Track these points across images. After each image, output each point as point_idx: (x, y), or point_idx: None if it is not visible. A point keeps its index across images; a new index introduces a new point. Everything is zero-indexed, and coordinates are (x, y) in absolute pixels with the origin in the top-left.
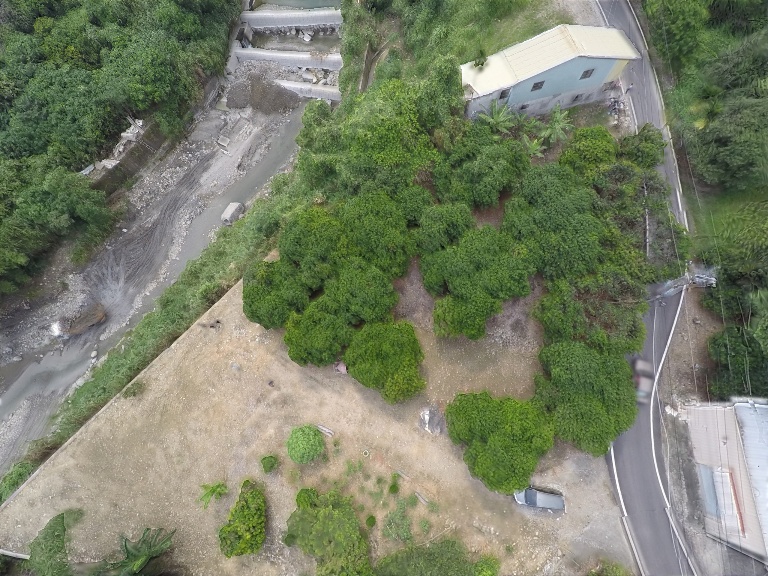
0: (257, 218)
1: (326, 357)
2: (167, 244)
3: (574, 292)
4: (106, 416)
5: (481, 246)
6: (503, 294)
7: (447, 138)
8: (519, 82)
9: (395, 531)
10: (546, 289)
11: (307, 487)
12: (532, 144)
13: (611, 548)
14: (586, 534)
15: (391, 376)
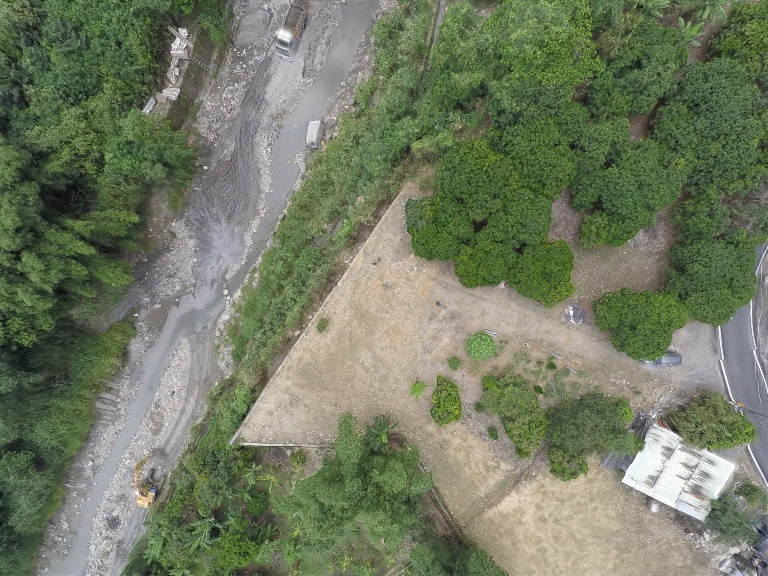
0: (379, 147)
1: (500, 280)
2: (255, 177)
3: (723, 195)
4: (303, 347)
5: (647, 164)
6: (659, 206)
7: (618, 44)
8: None
9: (556, 393)
10: (688, 192)
11: (483, 374)
12: (685, 29)
13: (709, 380)
14: (692, 374)
15: (554, 287)
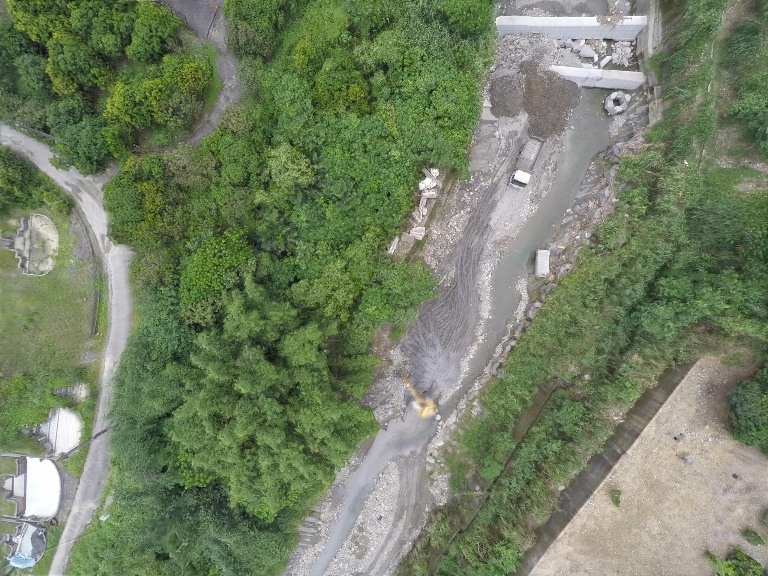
0: (670, 313)
1: None
2: (475, 303)
3: None
4: (587, 514)
5: None
6: None
7: None
8: None
9: None
10: None
11: None
12: None
13: None
14: None
15: None
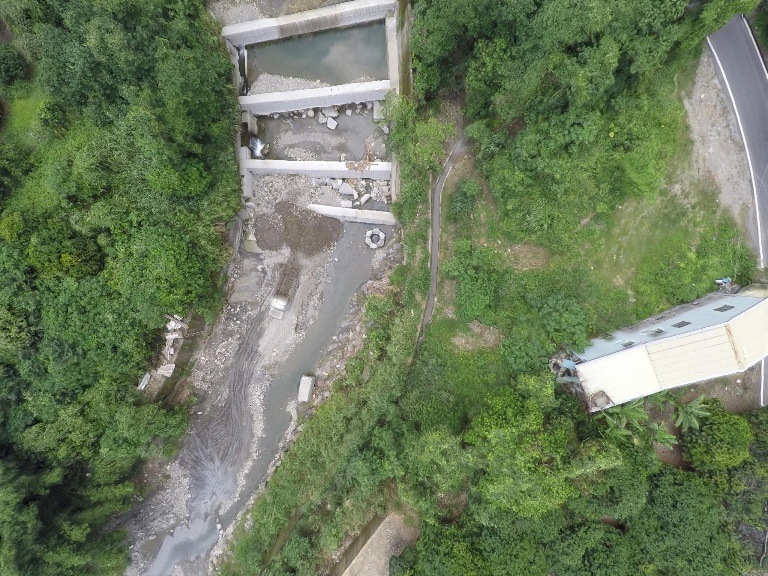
0: (366, 470)
1: None
2: (248, 423)
3: None
4: None
5: None
6: None
7: (590, 492)
8: (662, 390)
9: None
10: None
11: None
12: (659, 427)
13: None
14: None
15: None
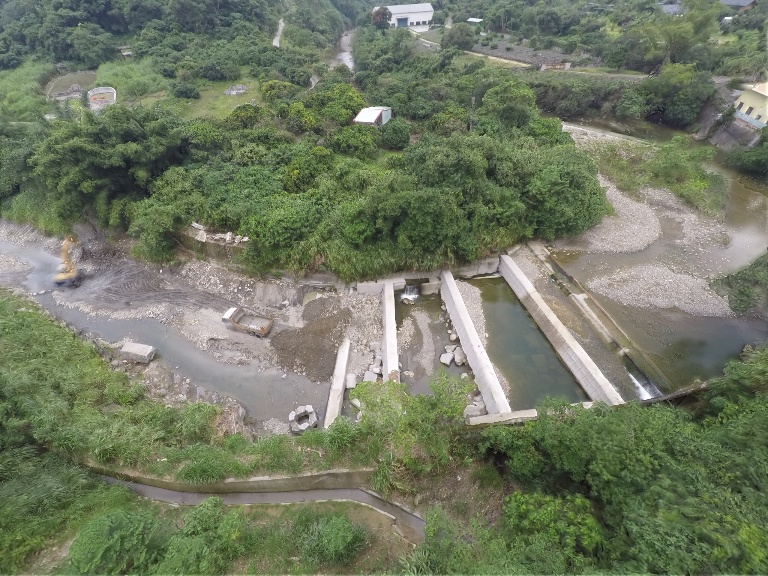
0: None
1: None
2: (131, 306)
3: None
4: None
5: None
6: None
7: None
8: None
9: None
10: None
11: None
12: None
13: None
14: None
15: None
